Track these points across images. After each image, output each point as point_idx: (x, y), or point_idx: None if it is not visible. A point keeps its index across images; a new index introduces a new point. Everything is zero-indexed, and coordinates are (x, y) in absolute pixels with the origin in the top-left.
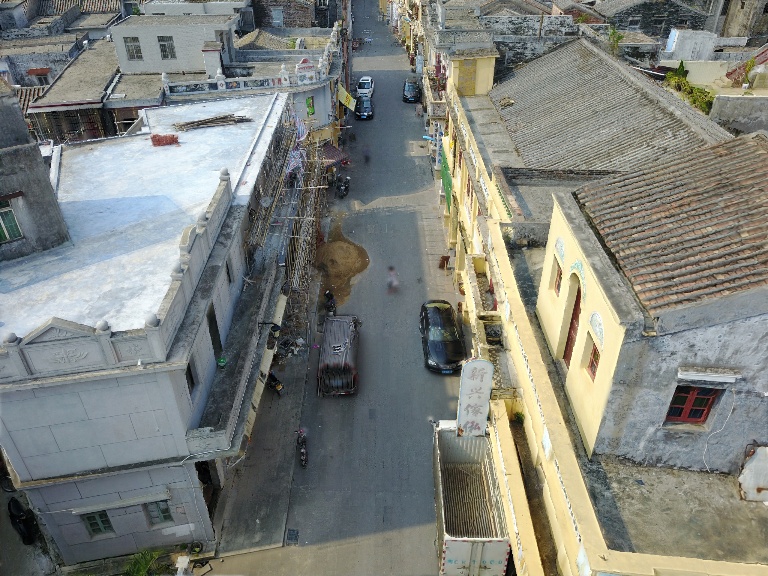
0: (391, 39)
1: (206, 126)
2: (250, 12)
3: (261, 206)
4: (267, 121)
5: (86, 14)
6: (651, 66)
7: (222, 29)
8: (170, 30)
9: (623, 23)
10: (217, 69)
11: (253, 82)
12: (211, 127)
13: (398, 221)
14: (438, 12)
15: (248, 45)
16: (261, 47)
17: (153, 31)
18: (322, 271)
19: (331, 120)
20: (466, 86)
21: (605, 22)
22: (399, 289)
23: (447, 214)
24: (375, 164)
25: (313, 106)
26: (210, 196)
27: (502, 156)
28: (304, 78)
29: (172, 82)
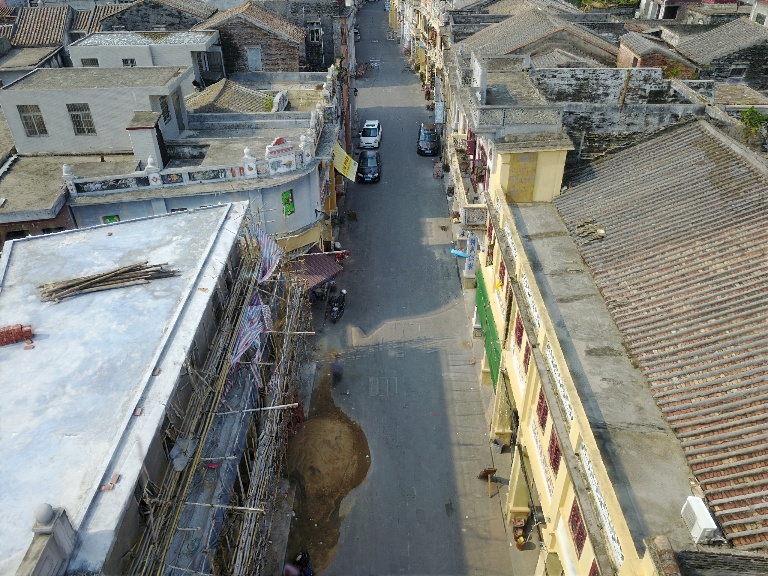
0: (402, 63)
1: (95, 290)
2: (218, 52)
3: (151, 520)
4: (201, 274)
5: (18, 48)
6: (767, 137)
7: (160, 94)
8: (84, 95)
9: (722, 73)
10: (151, 153)
11: (202, 173)
12: (104, 291)
13: (413, 371)
14: (473, 67)
15: (206, 107)
16: (224, 109)
17: (59, 97)
18: (296, 485)
19: (319, 215)
20: (520, 190)
21: (697, 71)
22: (417, 531)
23: (486, 369)
24: (381, 259)
25: (292, 202)
26: (27, 541)
27: (605, 366)
28: (278, 165)
29: (79, 178)
